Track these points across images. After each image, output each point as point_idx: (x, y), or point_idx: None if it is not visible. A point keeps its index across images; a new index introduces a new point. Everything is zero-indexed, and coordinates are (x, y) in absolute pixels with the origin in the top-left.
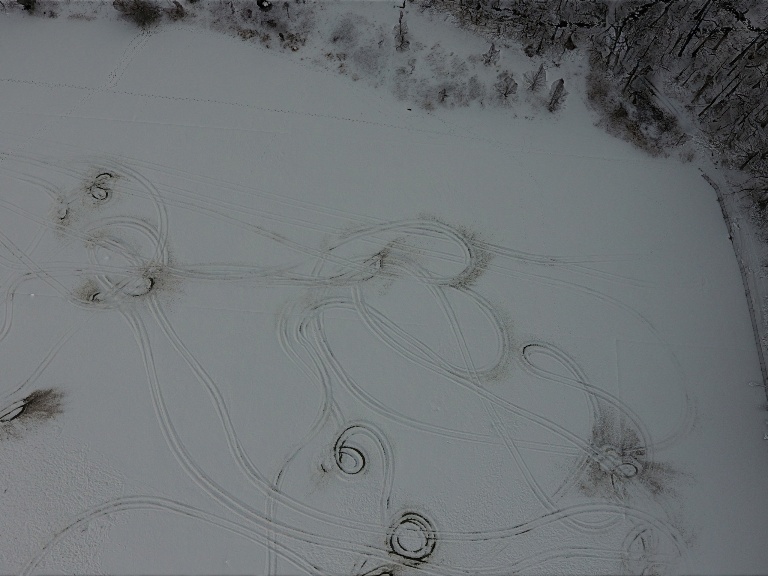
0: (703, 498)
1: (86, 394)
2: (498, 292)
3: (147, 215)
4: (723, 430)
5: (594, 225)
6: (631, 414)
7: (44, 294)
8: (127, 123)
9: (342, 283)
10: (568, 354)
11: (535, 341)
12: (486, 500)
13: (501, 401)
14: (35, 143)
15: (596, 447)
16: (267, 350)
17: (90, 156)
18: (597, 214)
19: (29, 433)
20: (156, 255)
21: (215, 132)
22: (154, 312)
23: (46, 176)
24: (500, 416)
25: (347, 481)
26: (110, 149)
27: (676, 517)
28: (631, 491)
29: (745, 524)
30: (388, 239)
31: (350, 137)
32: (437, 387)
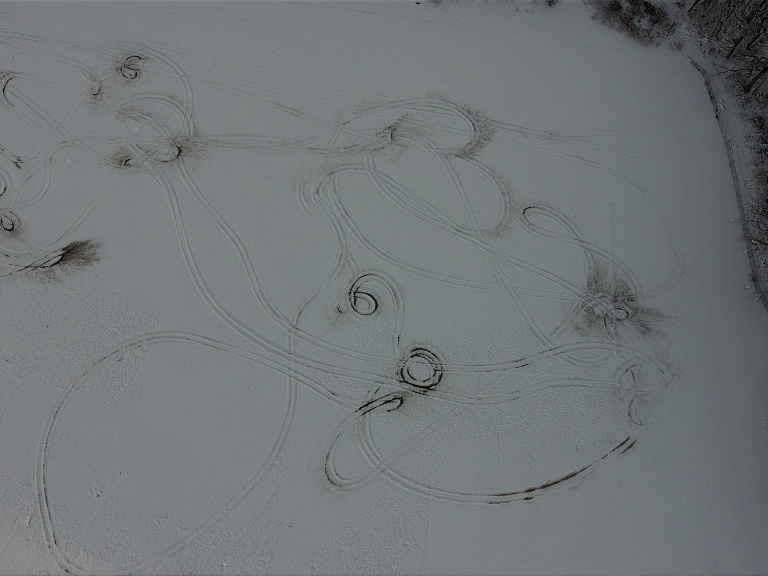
0: (688, 338)
1: (120, 245)
2: (500, 161)
3: (174, 92)
4: (707, 281)
5: (590, 104)
6: (623, 267)
7: (80, 159)
8: (154, 12)
9: (356, 152)
10: (565, 215)
11: (534, 204)
12: (489, 338)
13: (503, 255)
14: (69, 29)
15: (590, 294)
16: (287, 209)
17: (120, 41)
18: (593, 95)
19: (68, 277)
20: (183, 127)
21: (236, 21)
22: (182, 176)
23: (79, 58)
24: (502, 267)
25: (361, 321)
26: (139, 35)
27: (663, 354)
28: (622, 332)
29: (727, 360)
30: (398, 115)
31: (362, 26)
32: (444, 242)
